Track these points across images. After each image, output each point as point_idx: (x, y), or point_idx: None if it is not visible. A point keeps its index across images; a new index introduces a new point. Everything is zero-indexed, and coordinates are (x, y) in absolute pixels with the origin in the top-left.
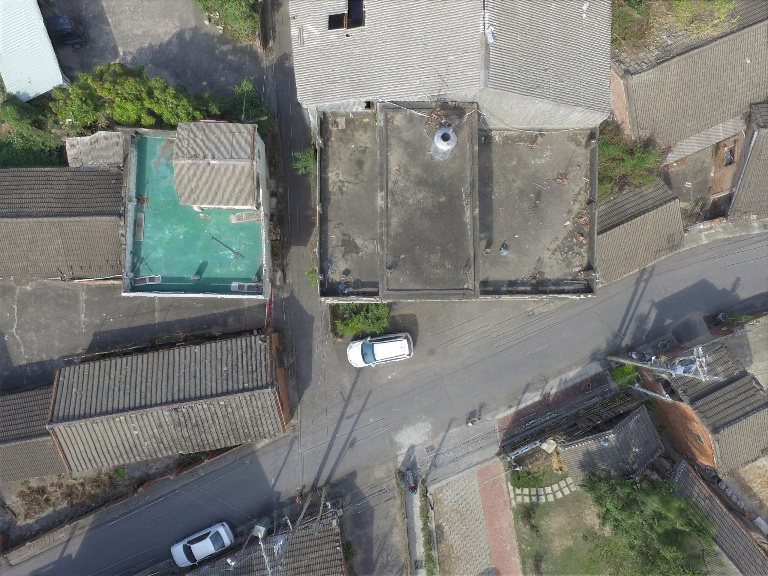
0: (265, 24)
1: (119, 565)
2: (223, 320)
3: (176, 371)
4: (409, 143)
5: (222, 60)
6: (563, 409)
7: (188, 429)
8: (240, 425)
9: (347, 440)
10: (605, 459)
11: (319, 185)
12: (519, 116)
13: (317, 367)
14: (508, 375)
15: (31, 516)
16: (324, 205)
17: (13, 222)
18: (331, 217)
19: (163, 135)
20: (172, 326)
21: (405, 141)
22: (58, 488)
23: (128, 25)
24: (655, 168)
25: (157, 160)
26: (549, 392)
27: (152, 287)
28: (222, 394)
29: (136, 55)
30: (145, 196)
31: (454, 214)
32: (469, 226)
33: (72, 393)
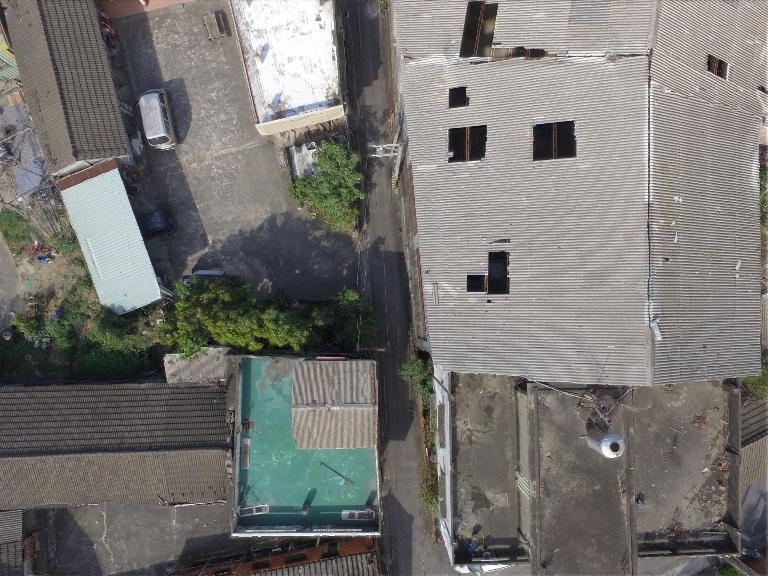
0: (358, 207)
1: None
2: None
3: None
4: (561, 427)
5: (315, 247)
6: None
7: None
8: None
9: None
10: None
11: (451, 443)
12: None
13: (417, 569)
14: None
15: None
16: None
17: (115, 456)
18: (460, 469)
19: None
20: None
21: (557, 424)
22: None
23: (217, 211)
24: None
25: (262, 381)
26: None
27: (259, 518)
28: None
29: (226, 243)
30: (250, 420)
31: (610, 503)
32: (626, 516)
33: None
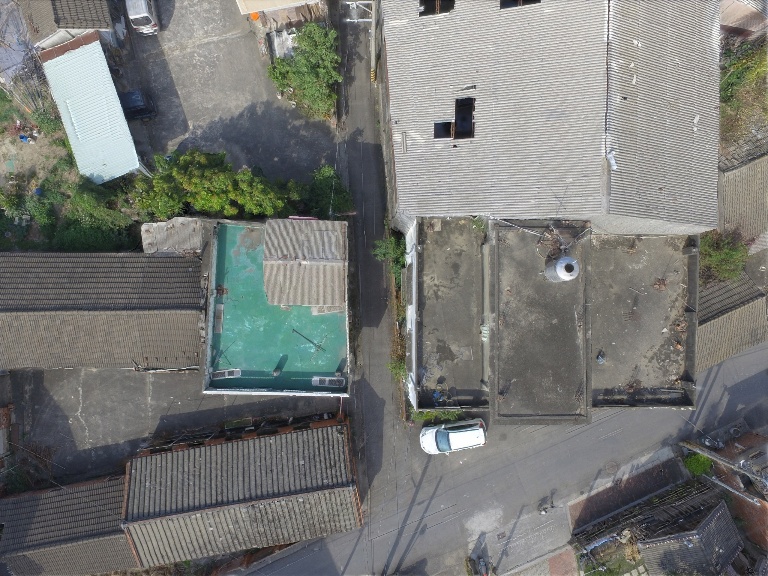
0: (338, 99)
1: None
2: (293, 404)
3: (252, 464)
4: (521, 263)
5: (294, 135)
6: (635, 496)
7: (264, 524)
8: (317, 520)
9: (418, 527)
10: (688, 559)
11: (417, 293)
12: (624, 227)
13: (388, 452)
14: (580, 461)
15: None
16: (419, 310)
17: (90, 315)
18: (426, 322)
19: (244, 224)
20: (241, 410)
21: (517, 260)
22: None
23: (198, 98)
24: (739, 261)
25: (237, 249)
26: (621, 478)
27: (231, 381)
28: (301, 491)
29: (206, 129)
30: (224, 286)
31: (566, 337)
32: (581, 349)
33: (145, 487)
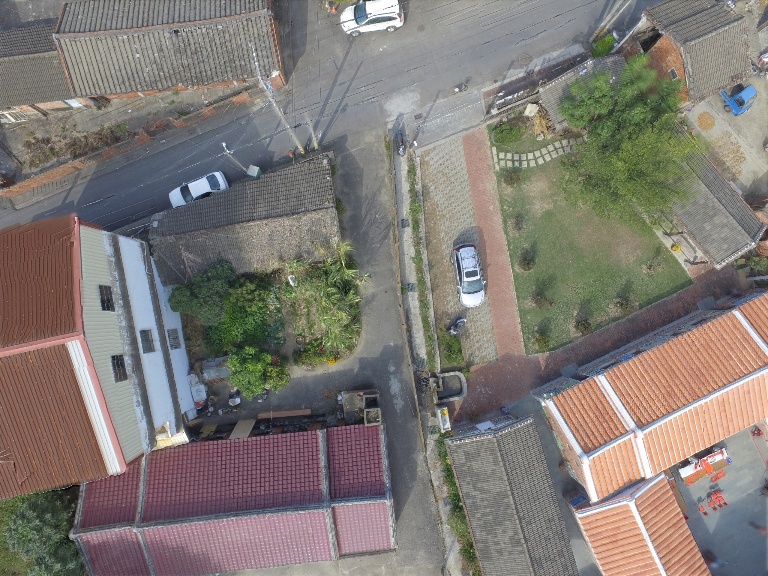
0: None
1: (119, 212)
2: None
3: (177, 4)
4: None
5: None
6: None
7: (187, 57)
8: (237, 56)
9: (339, 105)
10: (583, 90)
11: None
12: None
13: (312, 37)
14: (494, 52)
15: (36, 164)
16: None
17: None
18: None
19: None
20: None
21: None
22: (62, 138)
23: None
24: None
25: None
26: (533, 69)
27: None
28: None
29: None
30: None
31: None
32: None
33: (78, 18)
